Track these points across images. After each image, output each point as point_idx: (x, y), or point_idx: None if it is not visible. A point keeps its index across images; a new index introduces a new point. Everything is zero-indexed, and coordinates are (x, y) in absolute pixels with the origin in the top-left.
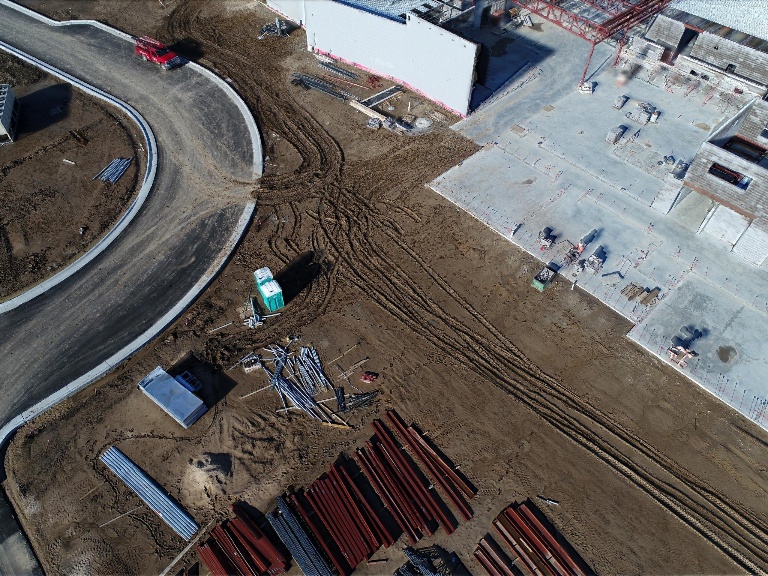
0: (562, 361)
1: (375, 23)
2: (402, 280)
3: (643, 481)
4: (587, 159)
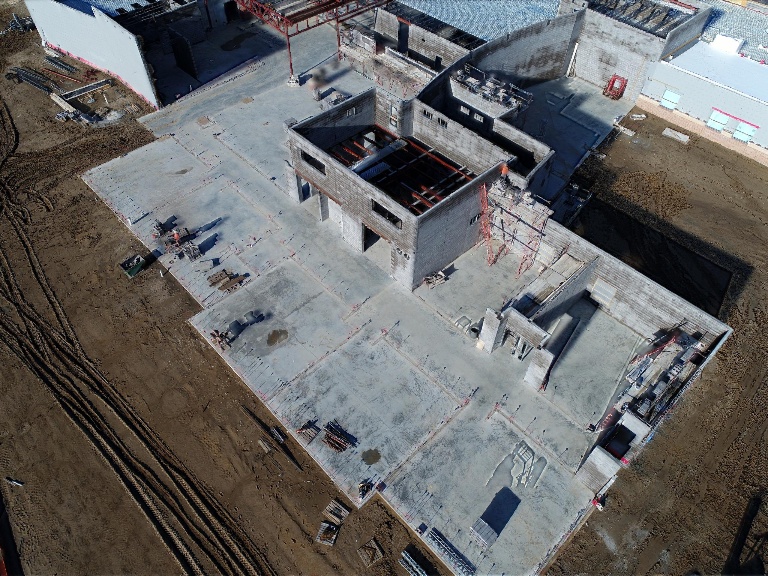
0: (111, 346)
1: (75, 17)
2: (0, 268)
3: (120, 462)
4: (255, 149)
